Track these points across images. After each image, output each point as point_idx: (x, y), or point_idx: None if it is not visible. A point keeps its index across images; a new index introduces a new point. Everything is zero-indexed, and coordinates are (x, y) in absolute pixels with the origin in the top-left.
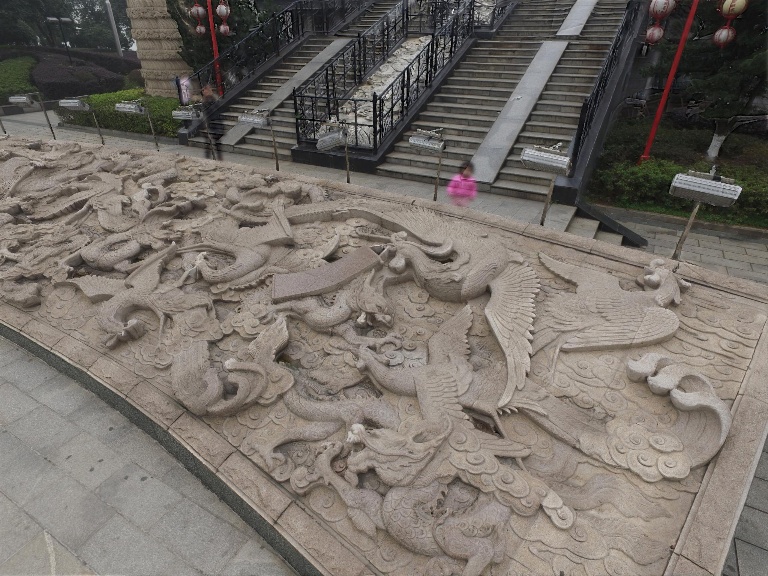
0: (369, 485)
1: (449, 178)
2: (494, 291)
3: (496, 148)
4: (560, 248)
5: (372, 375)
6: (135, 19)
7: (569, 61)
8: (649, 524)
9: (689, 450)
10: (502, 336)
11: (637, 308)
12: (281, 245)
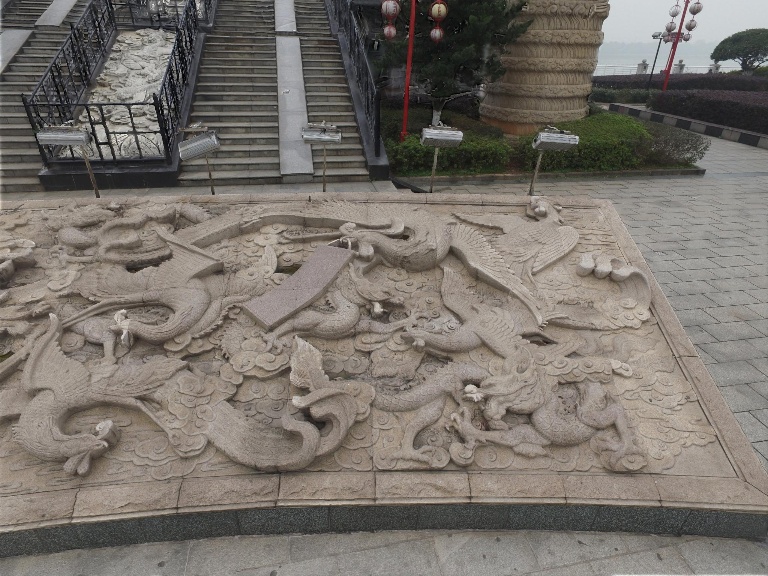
0: (511, 424)
1: (268, 176)
2: (462, 249)
3: (297, 140)
4: (461, 206)
5: (432, 348)
6: None
7: (309, 55)
8: (656, 350)
9: (639, 302)
10: (498, 278)
11: (552, 230)
12: (209, 274)
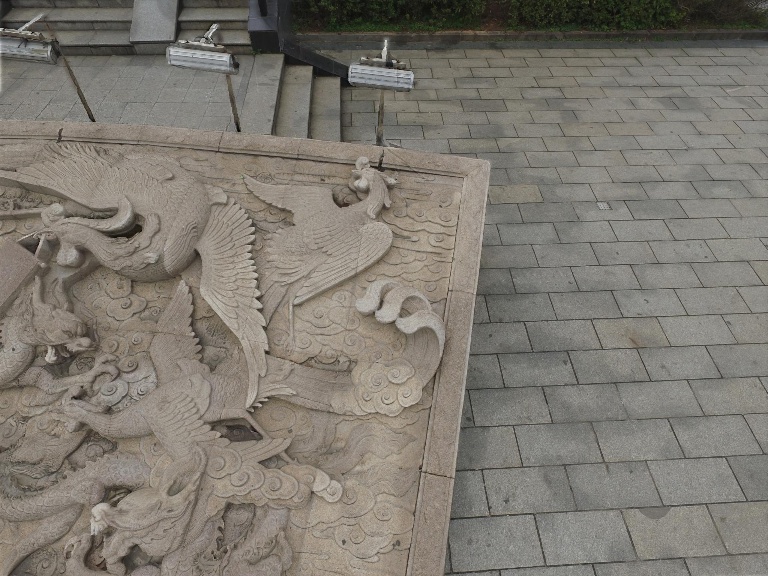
0: (140, 560)
1: (114, 43)
2: (204, 258)
3: None
4: (265, 160)
5: None
6: None
7: None
8: (401, 455)
9: (419, 371)
10: (228, 318)
11: (353, 231)
12: None
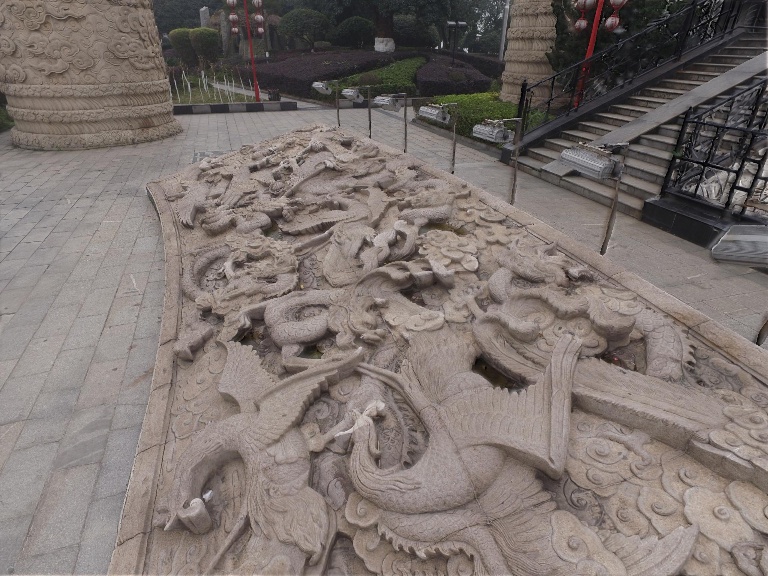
0: None
1: None
2: None
3: None
4: None
5: None
6: (515, 16)
7: None
8: None
9: None
10: None
11: None
12: (529, 464)
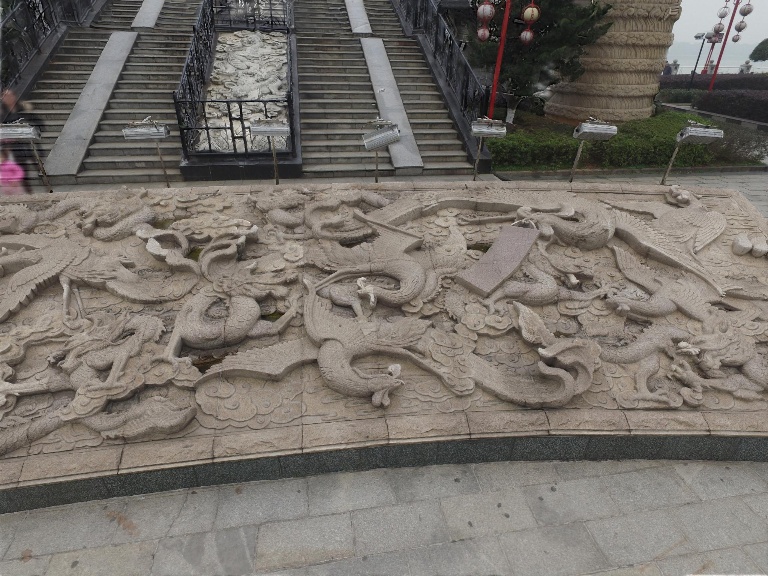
0: None
1: (383, 168)
2: (628, 230)
3: (402, 136)
4: (604, 194)
5: (632, 313)
6: None
7: (393, 56)
8: None
9: None
10: (670, 255)
11: (703, 215)
12: (412, 250)
